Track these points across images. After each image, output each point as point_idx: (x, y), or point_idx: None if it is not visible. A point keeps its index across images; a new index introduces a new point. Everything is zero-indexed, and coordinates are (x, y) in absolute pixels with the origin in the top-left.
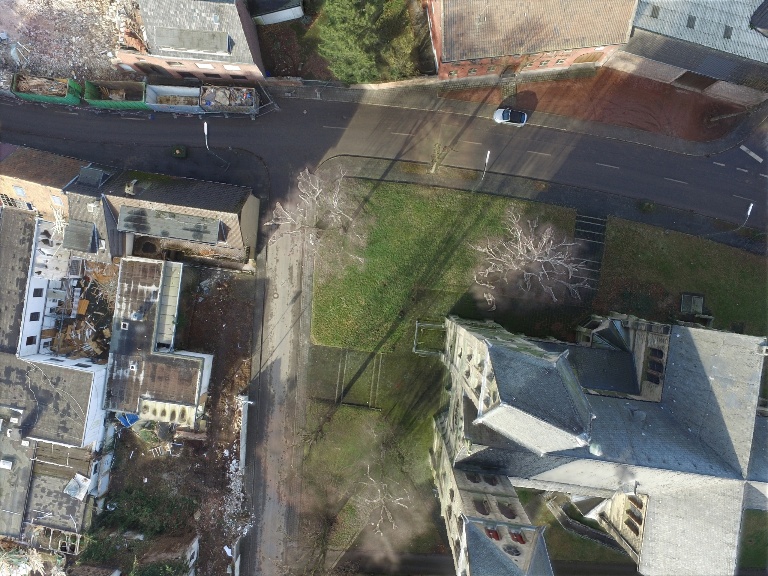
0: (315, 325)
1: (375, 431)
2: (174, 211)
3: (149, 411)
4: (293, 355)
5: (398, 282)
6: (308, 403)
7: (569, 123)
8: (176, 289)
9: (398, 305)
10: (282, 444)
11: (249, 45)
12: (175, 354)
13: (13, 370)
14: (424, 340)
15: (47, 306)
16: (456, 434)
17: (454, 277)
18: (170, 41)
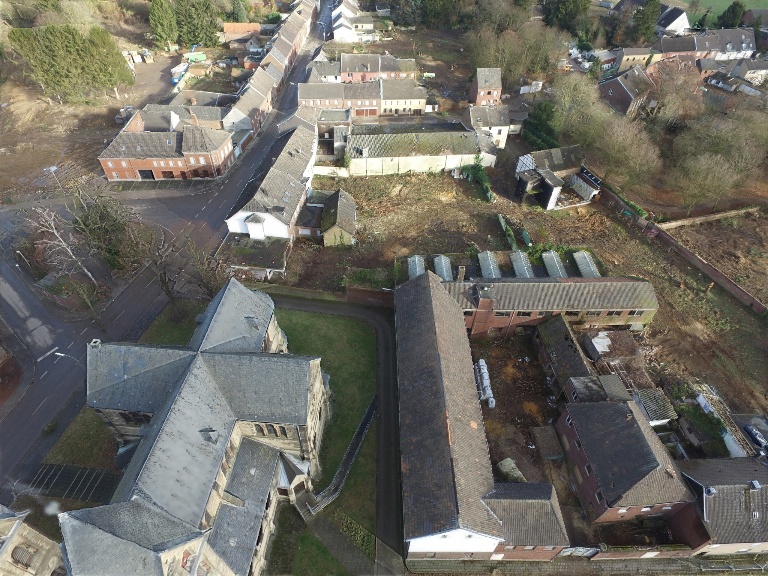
0: None
1: None
2: None
3: None
4: None
5: None
6: None
7: None
8: None
9: None
10: None
11: None
12: None
13: None
14: None
15: None
16: None
17: None
18: None
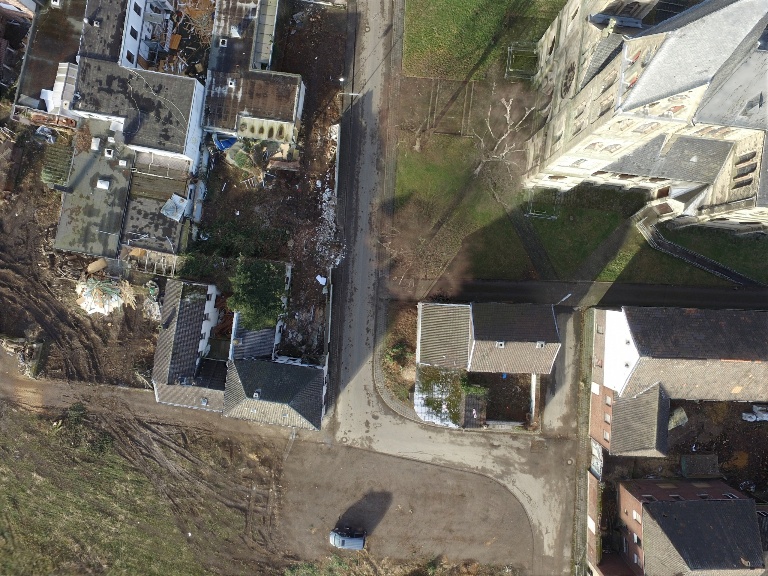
0: (407, 56)
1: (467, 158)
2: None
3: (247, 128)
4: (384, 88)
5: (490, 10)
6: (400, 134)
7: None
8: (274, 8)
9: (490, 32)
10: (374, 176)
11: None
12: (273, 71)
13: (115, 78)
14: (516, 66)
15: (143, 30)
16: (577, 73)
17: (545, 4)
18: None
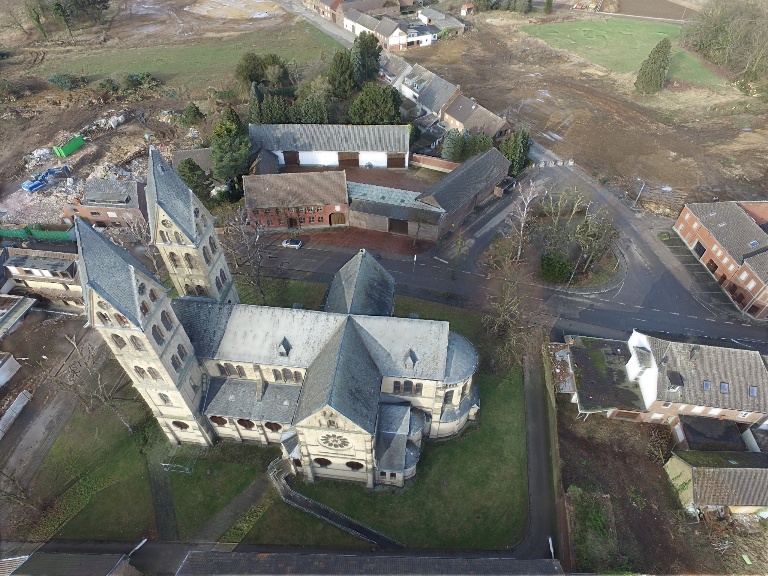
0: None
1: (130, 418)
2: (47, 256)
3: None
4: None
5: None
6: None
7: (328, 247)
8: (21, 313)
9: None
10: (39, 435)
11: (139, 201)
12: None
13: None
14: None
15: None
16: None
17: None
18: (95, 197)
